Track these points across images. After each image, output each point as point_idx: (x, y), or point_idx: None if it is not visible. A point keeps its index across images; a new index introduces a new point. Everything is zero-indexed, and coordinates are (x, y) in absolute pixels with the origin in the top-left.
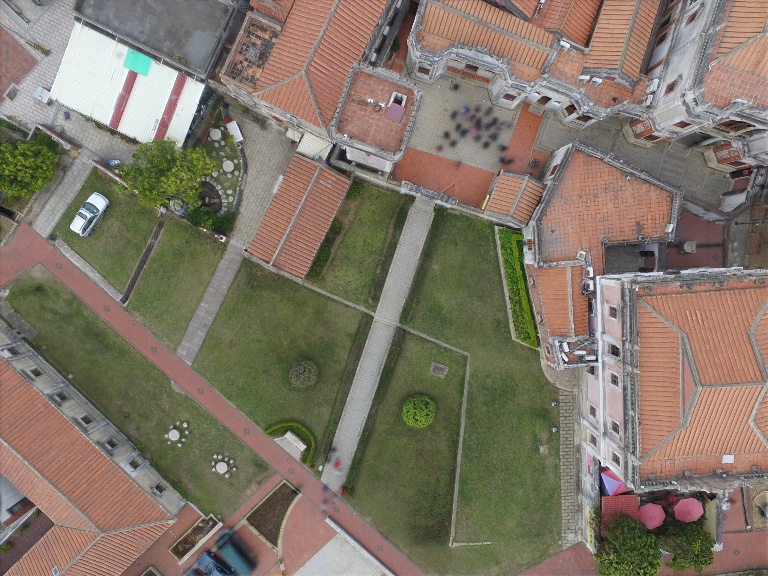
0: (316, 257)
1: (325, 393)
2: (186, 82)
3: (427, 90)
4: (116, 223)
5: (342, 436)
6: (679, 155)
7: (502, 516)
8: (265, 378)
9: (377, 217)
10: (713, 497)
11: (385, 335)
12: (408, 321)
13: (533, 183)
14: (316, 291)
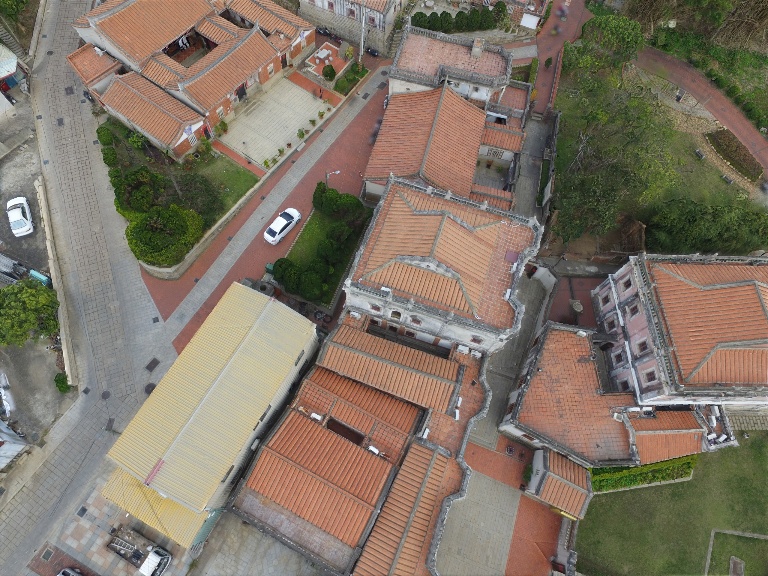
0: None
1: None
2: None
3: None
4: None
5: None
6: None
7: None
8: None
9: None
10: None
11: None
12: None
13: (549, 464)
14: None
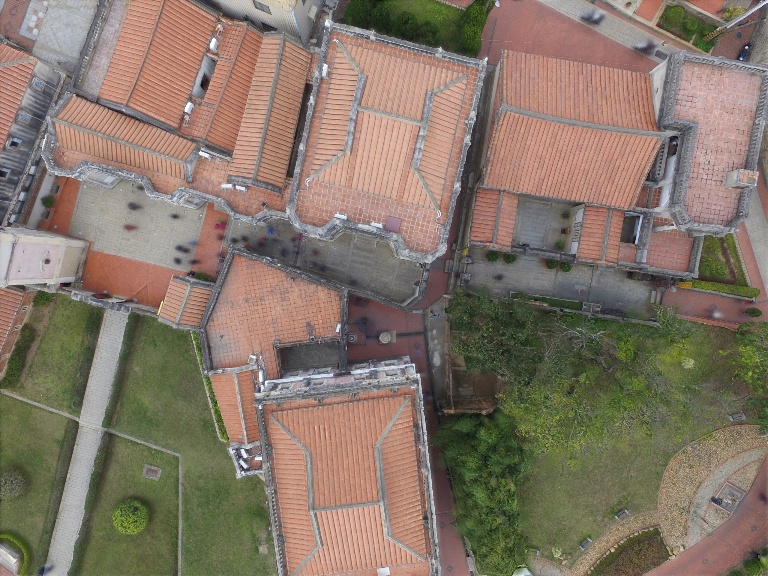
0: (8, 367)
1: (36, 502)
2: None
3: (109, 194)
4: None
5: (58, 545)
6: (367, 247)
7: None
8: None
9: (72, 322)
10: None
11: (93, 440)
12: (114, 425)
13: (202, 288)
14: (18, 399)
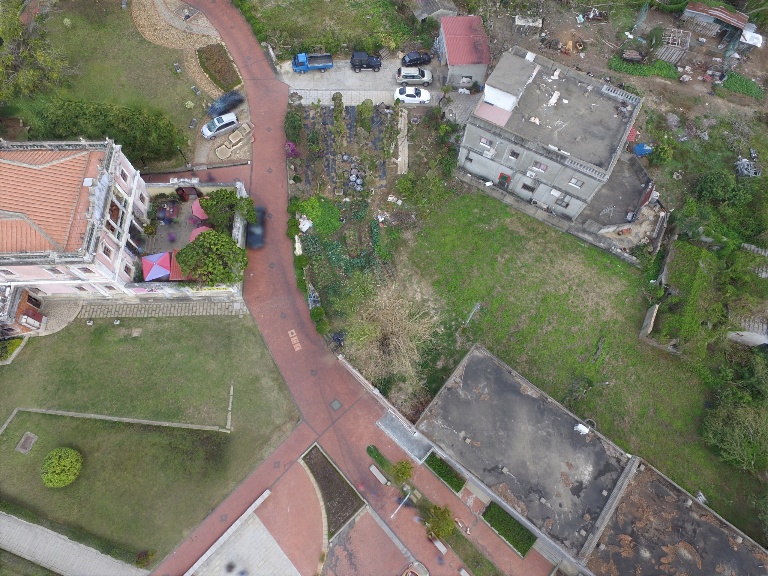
0: None
1: None
2: None
3: None
4: None
5: (72, 568)
6: None
7: (202, 375)
8: None
9: None
10: None
11: None
12: None
13: None
14: None
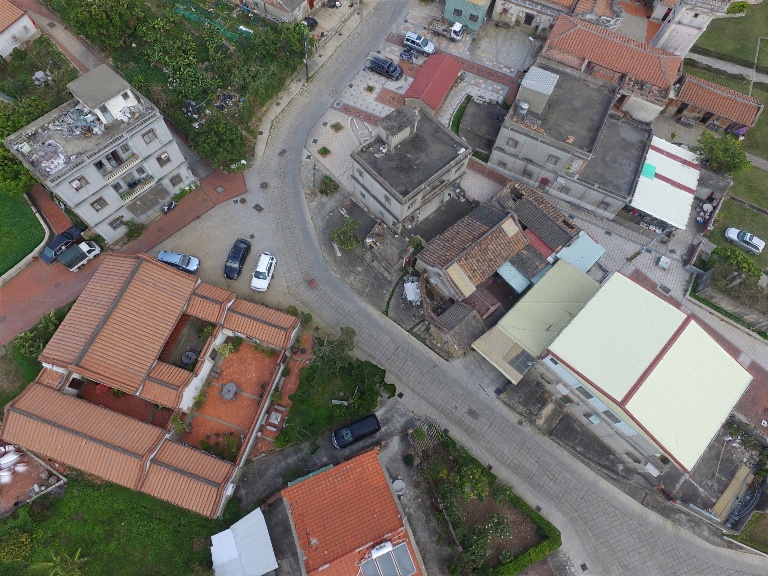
0: None
1: None
2: (654, 145)
3: None
4: (741, 228)
5: None
6: None
7: None
8: None
9: None
10: None
11: (763, 78)
12: None
13: None
14: None
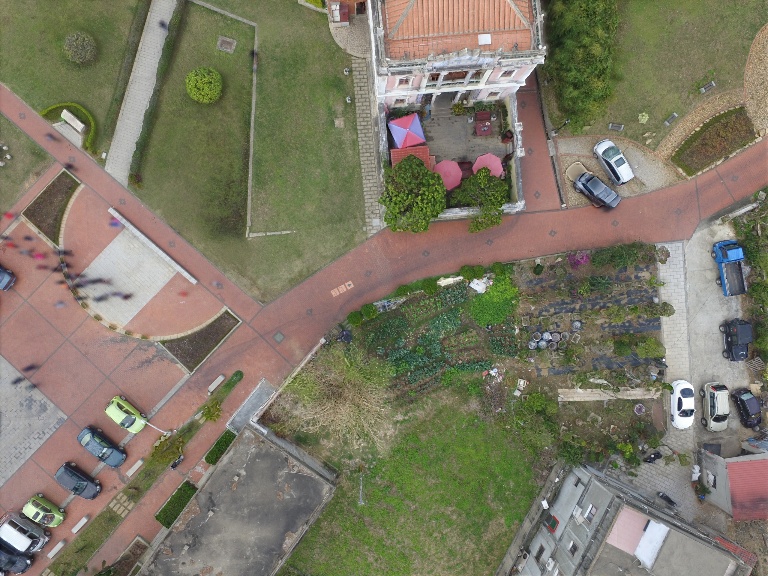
0: None
1: (106, 72)
2: None
3: None
4: None
5: (126, 119)
6: None
7: (300, 200)
8: (41, 57)
9: None
10: (512, 152)
11: (168, 7)
12: None
13: None
14: None
